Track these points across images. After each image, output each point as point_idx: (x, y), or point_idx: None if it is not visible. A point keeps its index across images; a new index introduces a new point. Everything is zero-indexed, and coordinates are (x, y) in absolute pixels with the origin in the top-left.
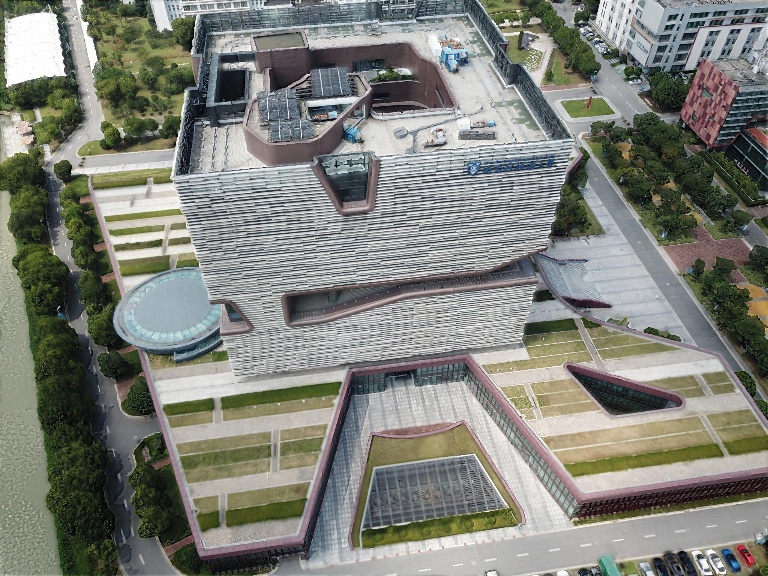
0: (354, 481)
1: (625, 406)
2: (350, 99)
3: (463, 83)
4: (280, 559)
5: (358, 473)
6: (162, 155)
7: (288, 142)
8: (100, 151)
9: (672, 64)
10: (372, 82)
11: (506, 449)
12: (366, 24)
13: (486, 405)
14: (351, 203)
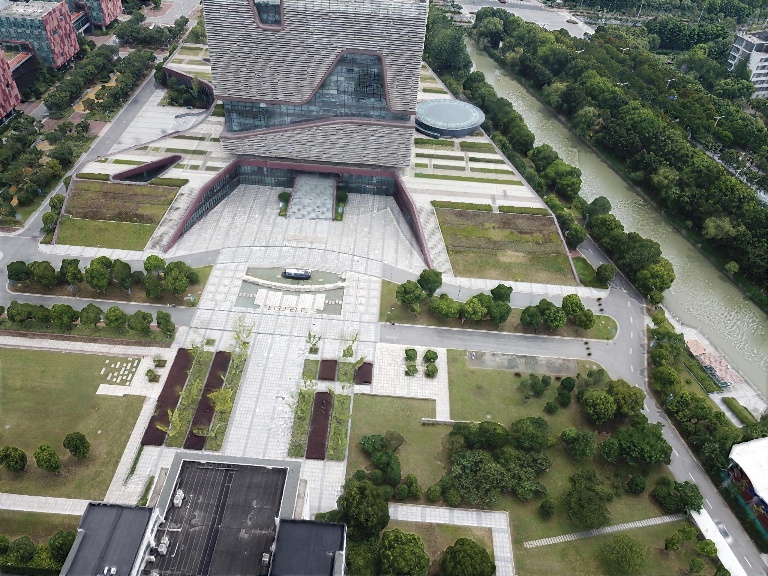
0: None
1: None
2: None
3: None
4: None
5: None
6: None
7: None
8: None
9: None
10: None
11: None
12: None
13: None
14: None
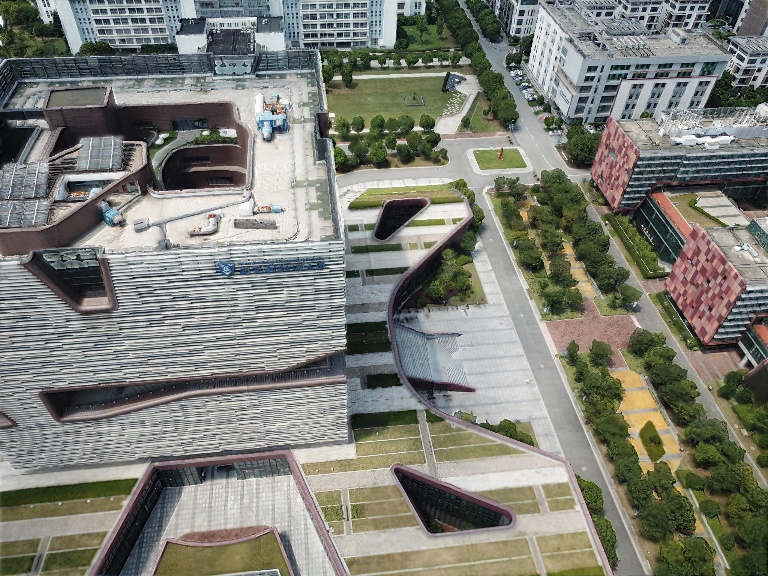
0: None
1: (462, 514)
2: (118, 174)
3: (273, 155)
4: None
5: None
6: None
7: (14, 229)
8: None
9: (595, 115)
10: (189, 145)
11: (319, 562)
12: (200, 77)
13: None
14: (93, 300)
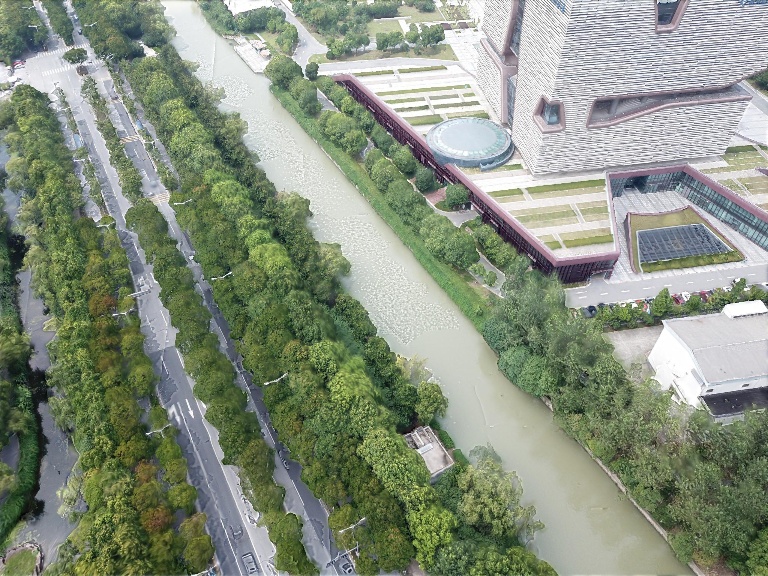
0: (621, 242)
1: None
2: None
3: None
4: (590, 279)
5: (622, 238)
6: (377, 63)
7: None
8: (327, 60)
9: None
10: None
11: (719, 225)
12: None
13: (698, 200)
14: (662, 26)
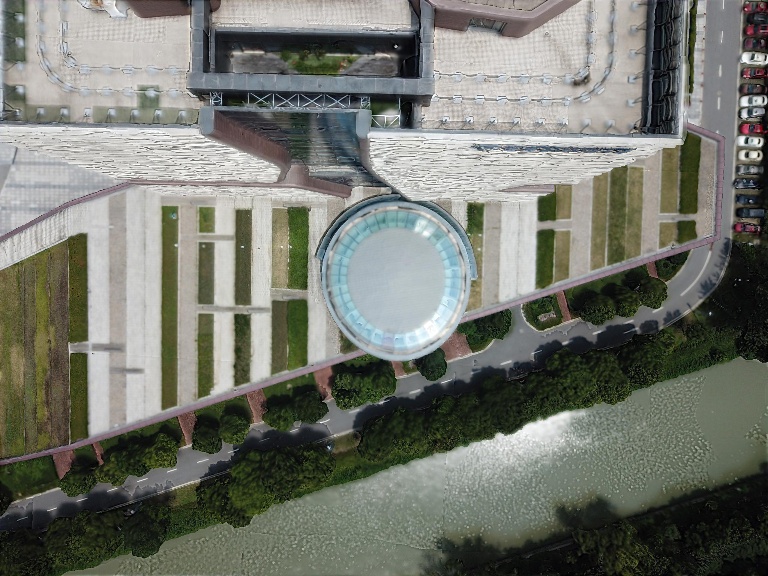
0: None
1: None
2: None
3: None
4: None
5: None
6: None
7: None
8: None
9: None
10: None
11: None
12: None
13: None
14: None
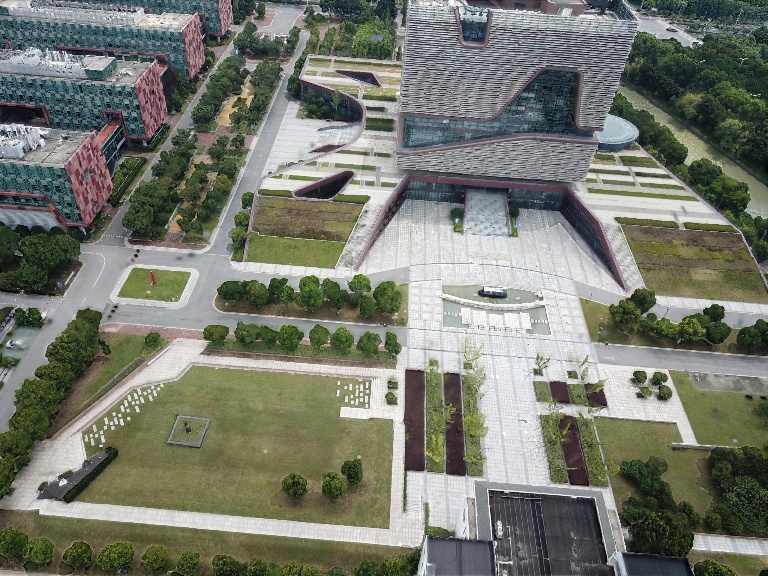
0: None
1: None
2: None
3: None
4: None
5: None
6: None
7: None
8: None
9: None
10: None
11: None
12: None
13: None
14: None
